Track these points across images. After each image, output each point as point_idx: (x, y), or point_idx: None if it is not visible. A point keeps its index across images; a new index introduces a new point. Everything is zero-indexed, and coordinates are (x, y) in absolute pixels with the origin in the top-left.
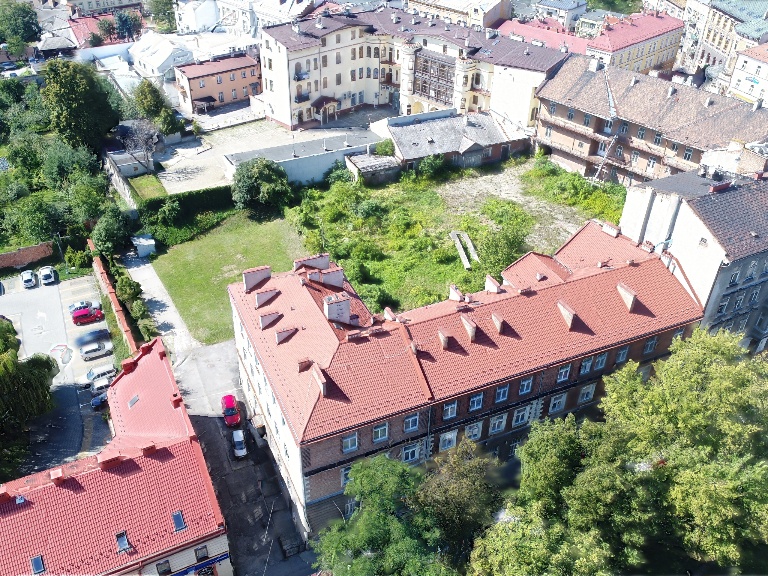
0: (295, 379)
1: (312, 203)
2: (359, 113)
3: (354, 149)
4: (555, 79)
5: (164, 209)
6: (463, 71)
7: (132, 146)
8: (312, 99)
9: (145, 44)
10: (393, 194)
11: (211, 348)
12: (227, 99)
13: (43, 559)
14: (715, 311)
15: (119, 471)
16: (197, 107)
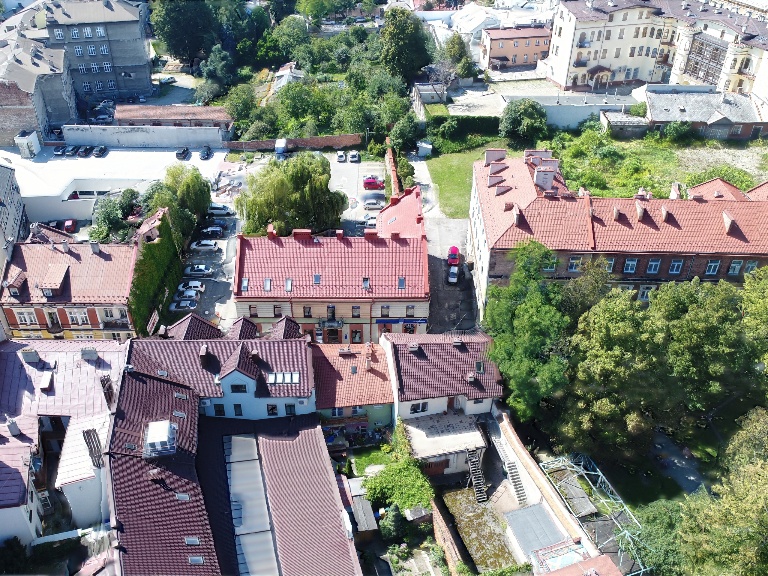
0: (500, 215)
1: (561, 142)
2: (630, 86)
3: (611, 106)
4: None
5: (445, 125)
6: (733, 54)
7: (434, 79)
8: (589, 66)
9: (465, 12)
10: (634, 147)
11: (452, 220)
12: (519, 61)
13: (321, 277)
14: None
15: (375, 243)
16: (492, 64)
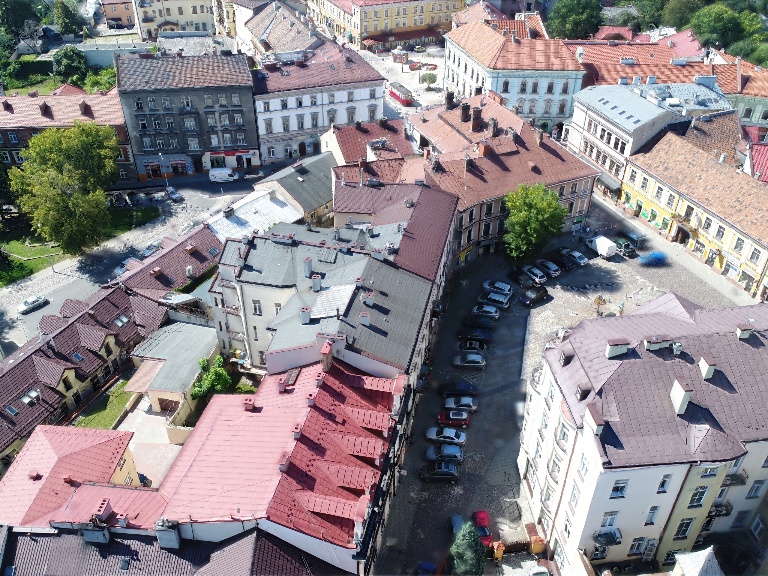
0: None
1: (93, 76)
2: None
3: (137, 49)
4: (258, 15)
5: (11, 68)
6: (225, 8)
7: (24, 35)
8: (158, 22)
9: None
10: None
11: None
12: None
13: None
14: (136, 125)
15: None
16: (109, 24)
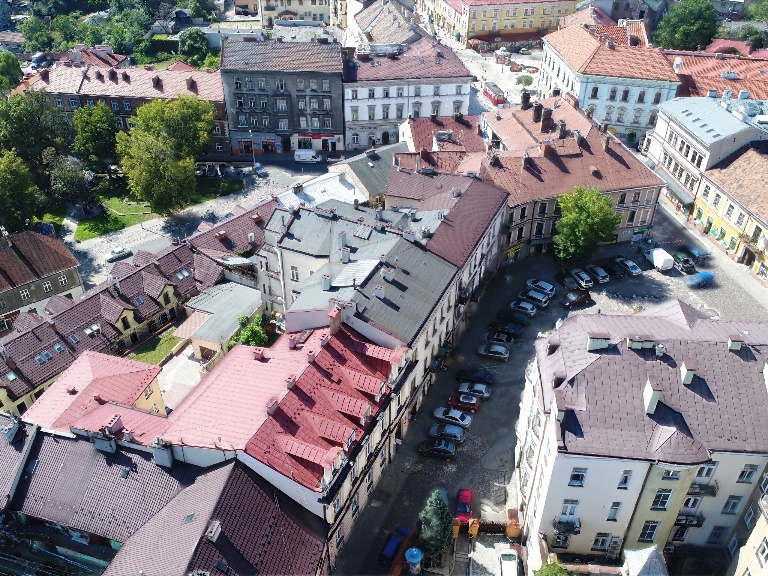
0: None
1: (211, 57)
2: None
3: (254, 35)
4: (367, 8)
5: (142, 45)
6: None
7: (158, 16)
8: (279, 11)
9: None
10: None
11: None
12: None
13: None
14: (234, 102)
15: None
16: (236, 10)
